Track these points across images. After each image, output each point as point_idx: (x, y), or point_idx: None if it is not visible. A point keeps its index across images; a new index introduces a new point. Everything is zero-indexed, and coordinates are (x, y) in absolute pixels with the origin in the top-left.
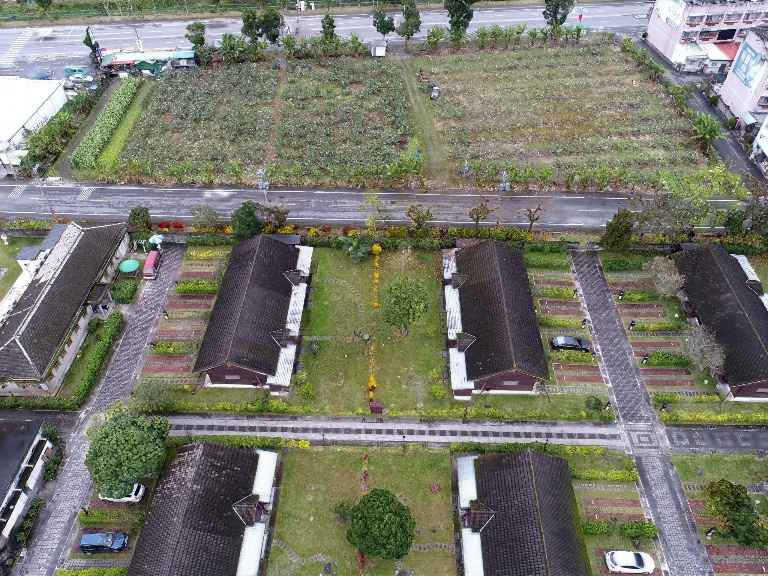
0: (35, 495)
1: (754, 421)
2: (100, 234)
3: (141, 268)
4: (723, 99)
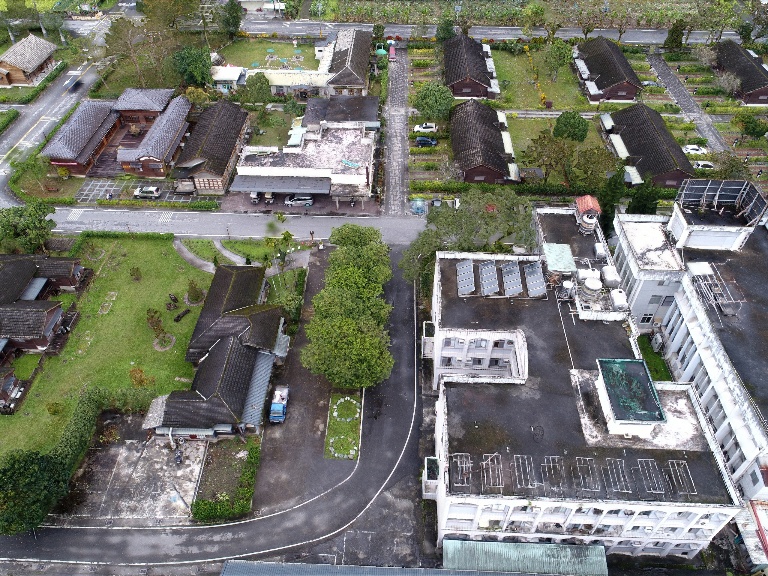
0: (380, 130)
1: (757, 112)
2: (363, 33)
3: (384, 57)
4: None
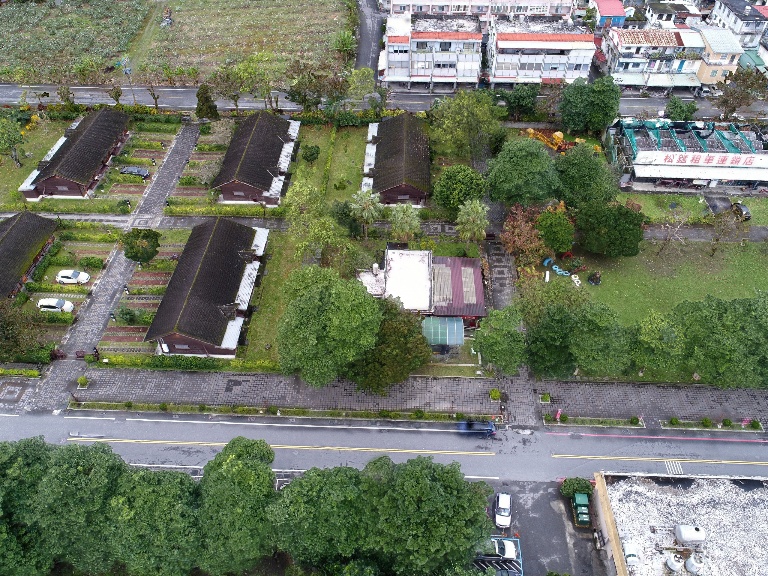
0: None
1: (225, 213)
2: None
3: None
4: None
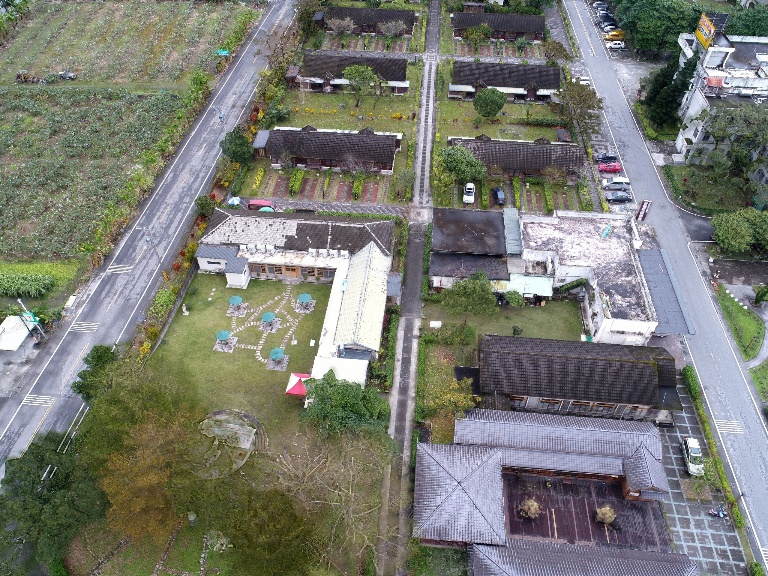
0: None
1: None
2: None
3: None
4: None
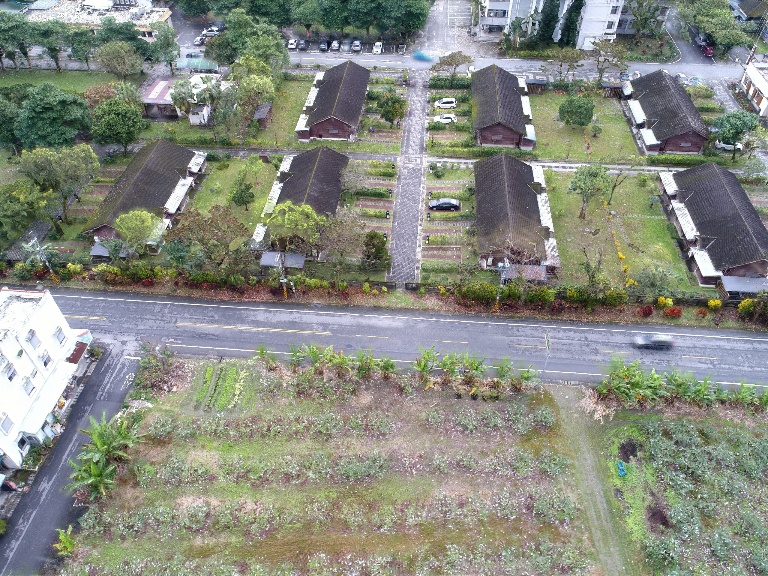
0: None
1: None
2: None
3: None
4: None
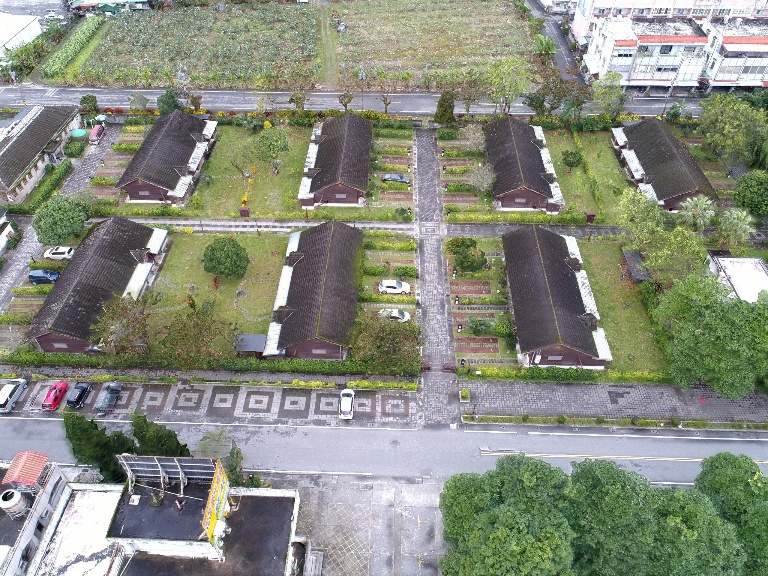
0: (1, 256)
1: (510, 220)
2: (57, 110)
3: None
4: (573, 30)
